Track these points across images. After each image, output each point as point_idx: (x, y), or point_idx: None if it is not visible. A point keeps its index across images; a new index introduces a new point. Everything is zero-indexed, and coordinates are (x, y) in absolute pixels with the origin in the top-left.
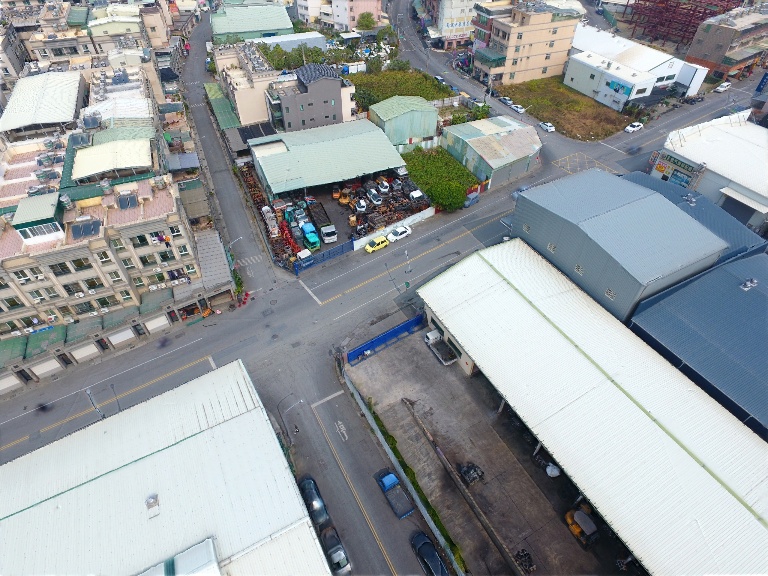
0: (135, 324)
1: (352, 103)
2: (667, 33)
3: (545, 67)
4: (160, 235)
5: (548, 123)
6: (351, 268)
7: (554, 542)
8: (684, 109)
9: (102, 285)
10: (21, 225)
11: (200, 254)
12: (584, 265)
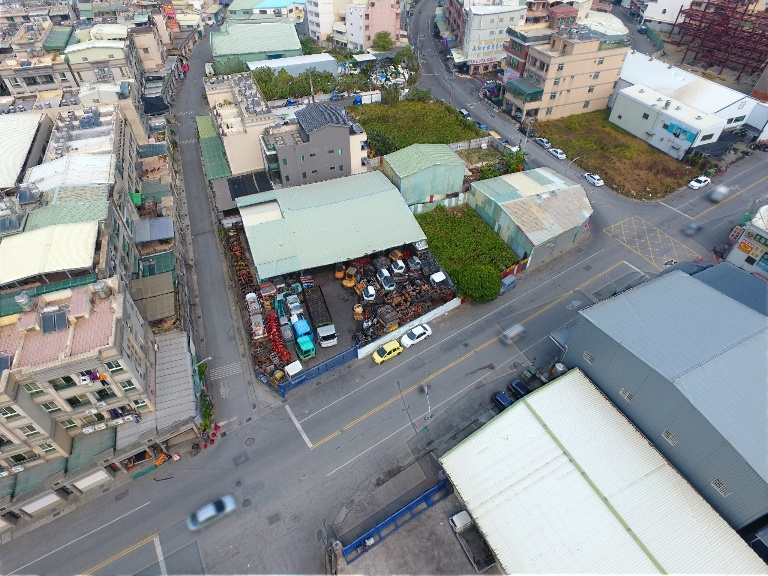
0: (59, 487)
1: (363, 152)
2: (725, 60)
3: (587, 101)
4: (93, 371)
5: (595, 175)
6: (353, 387)
7: None
8: (756, 158)
9: (11, 442)
10: None
11: (159, 371)
12: (679, 436)
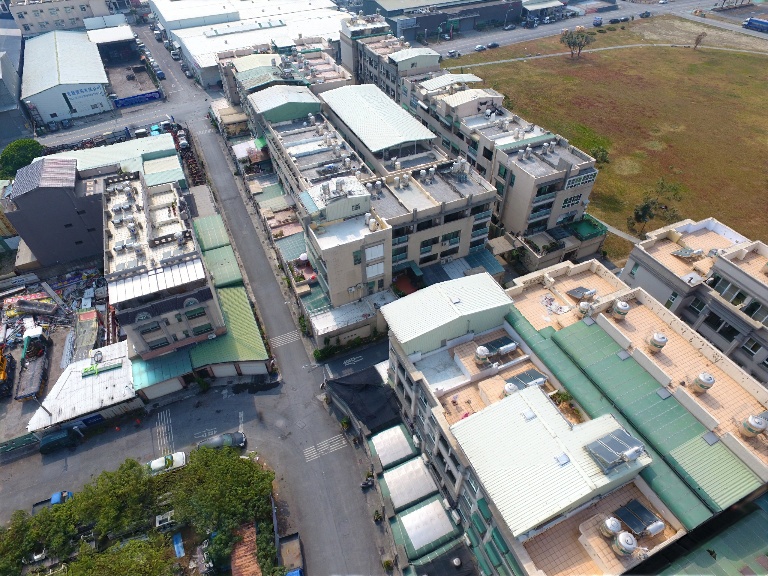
0: None
1: None
2: None
3: None
4: None
5: None
6: None
7: (116, 71)
8: None
9: None
10: None
11: None
12: None
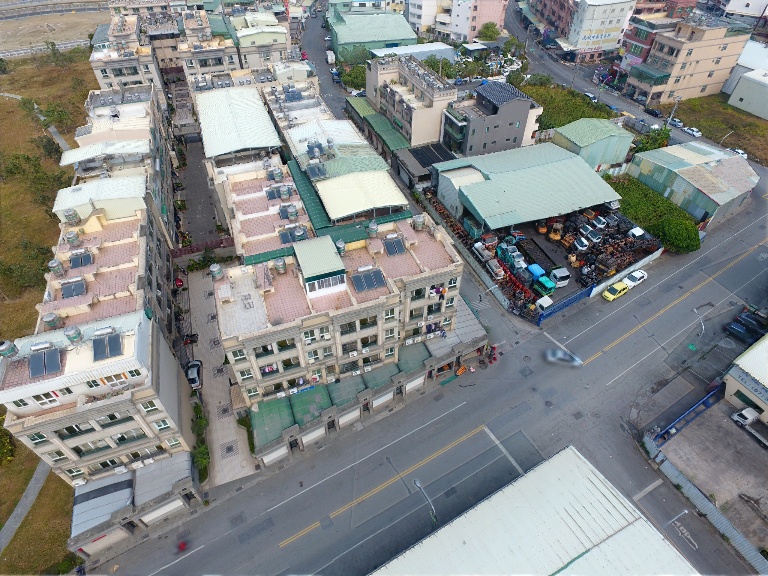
0: (399, 385)
1: (535, 125)
2: None
3: (705, 85)
4: (436, 287)
5: (739, 150)
6: (597, 319)
7: None
8: None
9: (375, 343)
10: (313, 278)
11: None
12: None
